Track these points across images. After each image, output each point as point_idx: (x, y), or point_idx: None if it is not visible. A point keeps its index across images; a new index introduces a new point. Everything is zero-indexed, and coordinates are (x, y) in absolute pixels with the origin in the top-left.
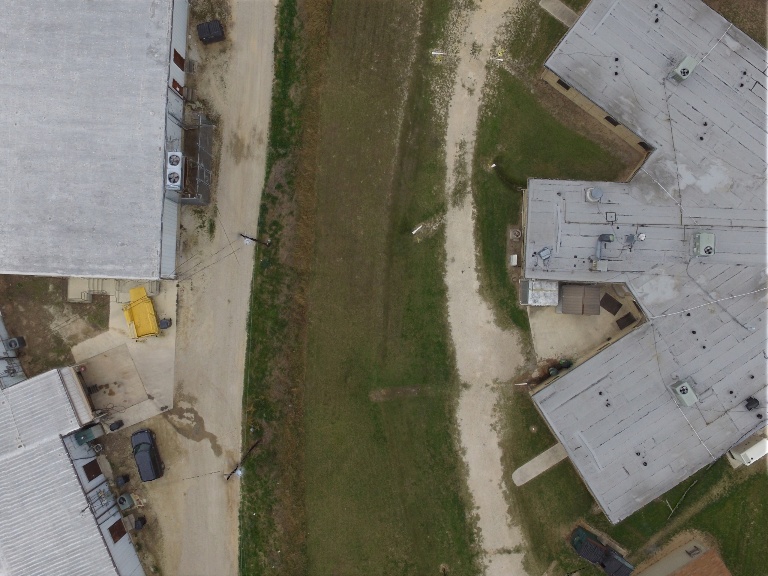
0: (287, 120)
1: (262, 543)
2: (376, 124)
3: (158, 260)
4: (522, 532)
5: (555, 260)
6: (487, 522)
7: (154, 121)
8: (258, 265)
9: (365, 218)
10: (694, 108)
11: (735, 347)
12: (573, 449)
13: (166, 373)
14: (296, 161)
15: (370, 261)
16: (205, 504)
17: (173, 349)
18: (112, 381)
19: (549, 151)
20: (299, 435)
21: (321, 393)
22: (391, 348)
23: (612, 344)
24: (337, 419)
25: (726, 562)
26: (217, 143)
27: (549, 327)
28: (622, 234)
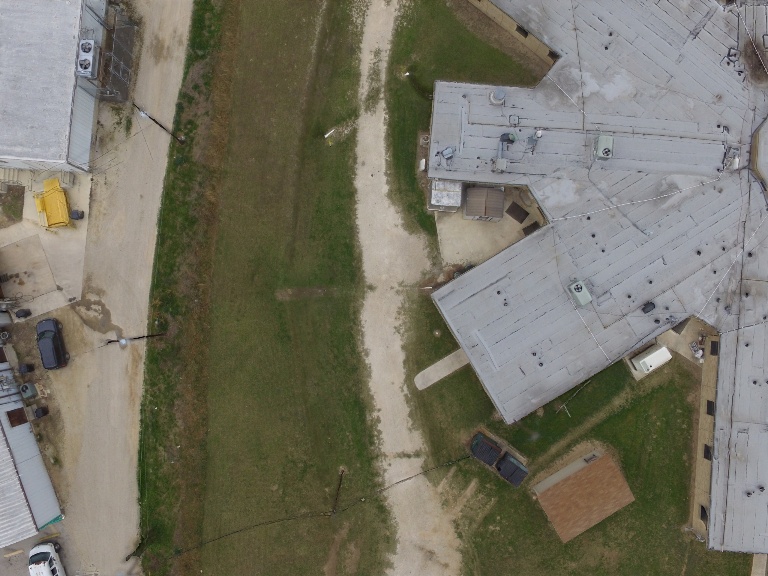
0: (207, 23)
1: (162, 438)
2: (294, 30)
3: (66, 143)
4: (423, 437)
5: (458, 160)
6: (388, 425)
7: (70, 10)
8: (171, 162)
9: (279, 120)
10: (600, 19)
11: (634, 252)
12: (470, 347)
13: (76, 265)
14: (213, 62)
15: (282, 162)
16: (108, 396)
17: (84, 241)
18: (22, 270)
19: (462, 62)
20: (204, 330)
21: (228, 290)
22: (299, 248)
23: (512, 245)
24: (242, 316)
25: (627, 475)
26: (138, 43)
27: (456, 233)
28: (524, 136)
